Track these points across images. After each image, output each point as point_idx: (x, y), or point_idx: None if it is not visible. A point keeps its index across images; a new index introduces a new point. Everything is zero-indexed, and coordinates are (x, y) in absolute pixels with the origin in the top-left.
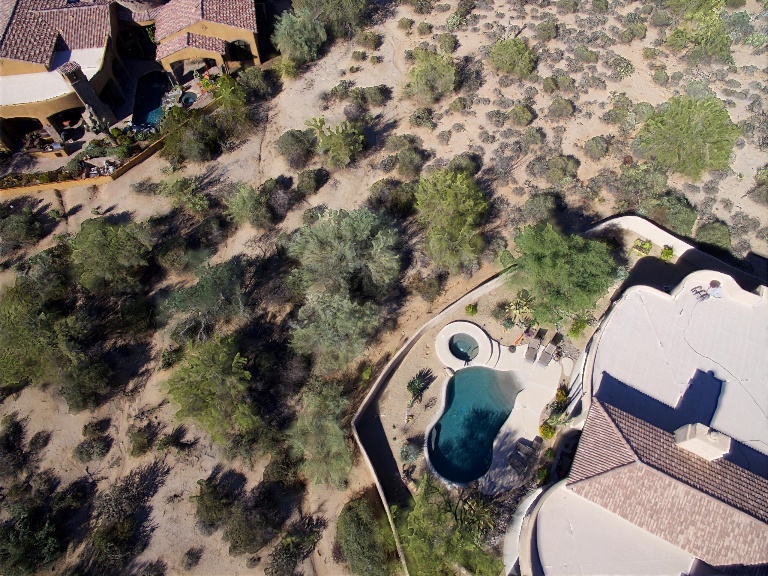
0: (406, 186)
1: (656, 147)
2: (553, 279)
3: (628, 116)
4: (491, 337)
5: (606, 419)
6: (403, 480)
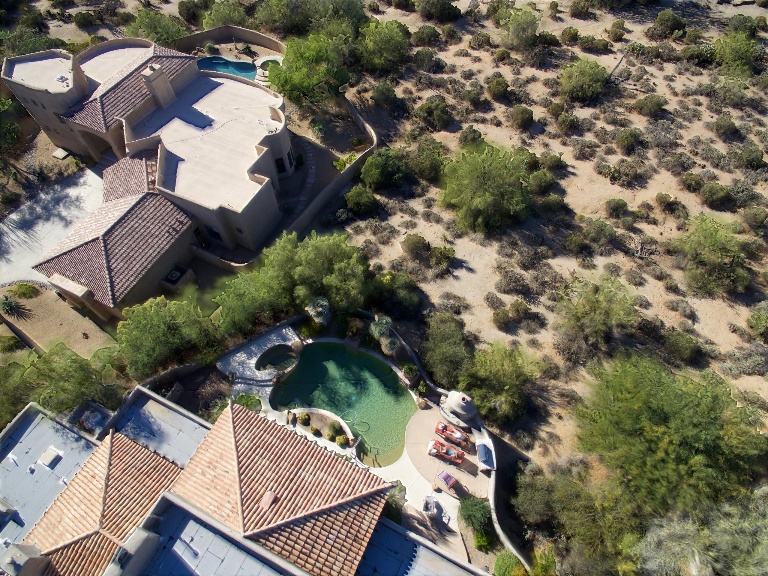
0: None
1: None
2: None
3: None
4: None
5: None
6: None
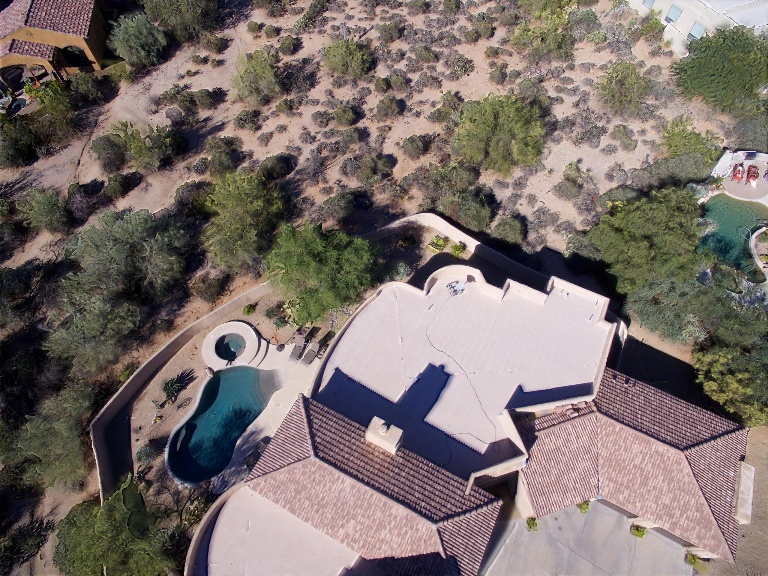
0: (209, 188)
1: (467, 144)
2: (302, 277)
3: (452, 114)
4: (262, 336)
5: (302, 415)
6: (134, 481)
